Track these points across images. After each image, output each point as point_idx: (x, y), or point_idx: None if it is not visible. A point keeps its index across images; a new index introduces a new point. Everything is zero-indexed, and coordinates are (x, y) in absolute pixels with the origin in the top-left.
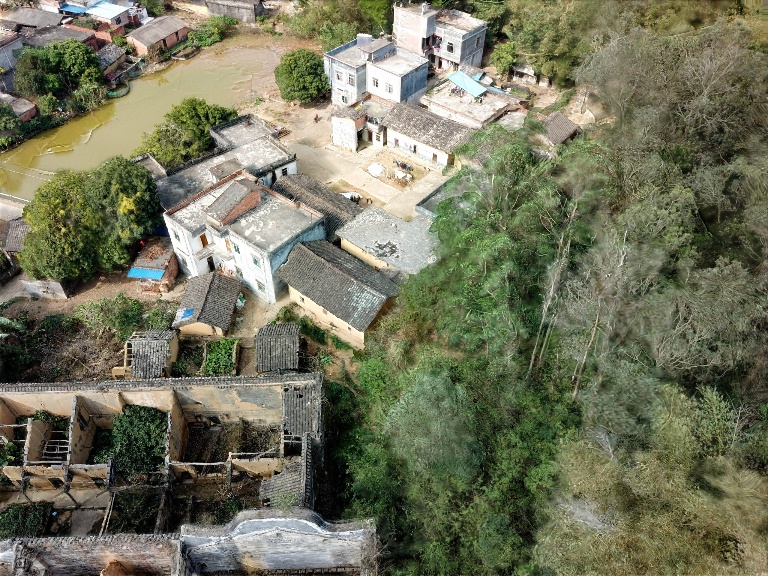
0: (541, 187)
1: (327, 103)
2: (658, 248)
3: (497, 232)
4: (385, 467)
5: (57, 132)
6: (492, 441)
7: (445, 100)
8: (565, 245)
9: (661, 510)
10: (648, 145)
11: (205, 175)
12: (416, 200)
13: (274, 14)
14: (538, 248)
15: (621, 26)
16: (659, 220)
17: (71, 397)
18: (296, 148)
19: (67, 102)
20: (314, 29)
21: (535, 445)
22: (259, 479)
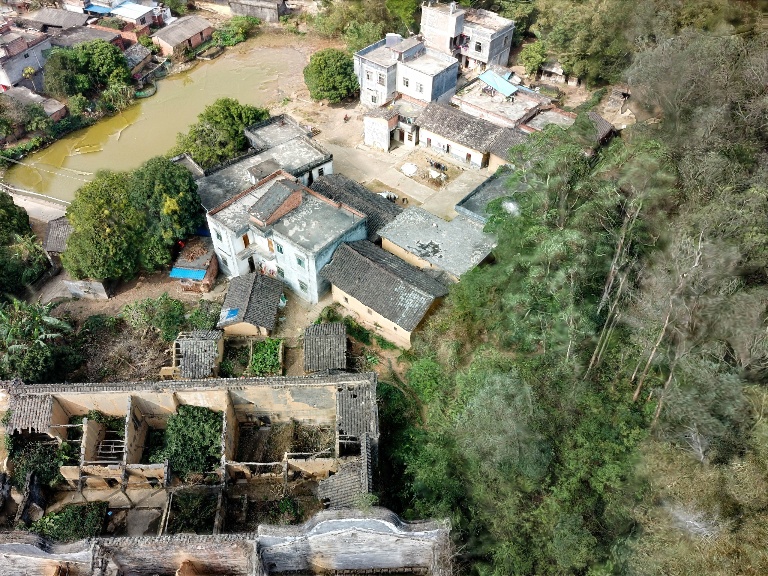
0: (600, 187)
1: (355, 103)
2: (729, 248)
3: (562, 232)
4: (446, 467)
5: (87, 132)
6: (555, 441)
7: (476, 100)
8: (626, 245)
9: (763, 511)
10: (713, 145)
11: (243, 175)
12: (452, 200)
13: (297, 14)
14: (597, 248)
15: (657, 25)
16: (732, 220)
17: (125, 397)
18: (327, 148)
19: (96, 102)
20: (338, 29)
21: (598, 445)
22: (312, 479)
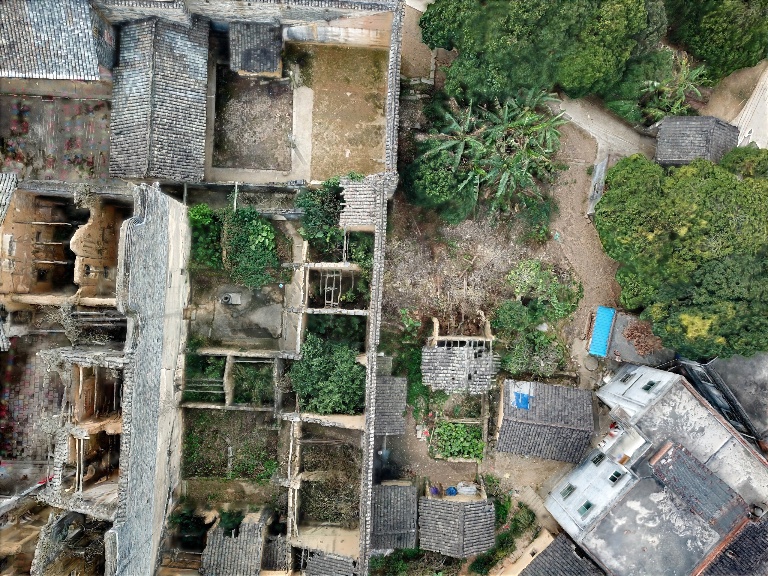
0: None
1: None
2: None
3: None
4: None
5: None
6: None
7: None
8: None
9: None
10: None
11: None
12: None
13: None
14: None
15: None
16: None
17: None
18: None
19: None
20: None
21: None
22: None
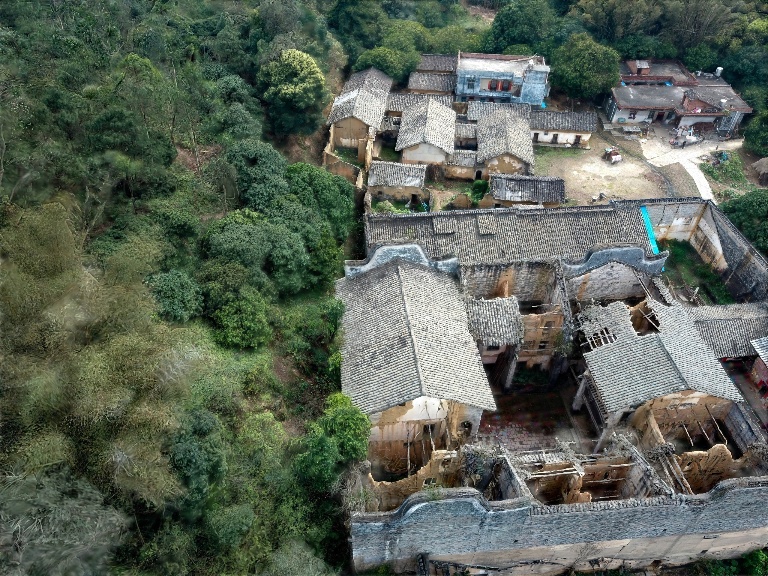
0: None
1: None
2: None
3: None
4: None
5: None
6: None
7: None
8: None
9: (116, 383)
10: None
11: None
12: None
13: None
14: None
15: None
16: None
17: None
18: None
19: None
20: None
21: None
22: None
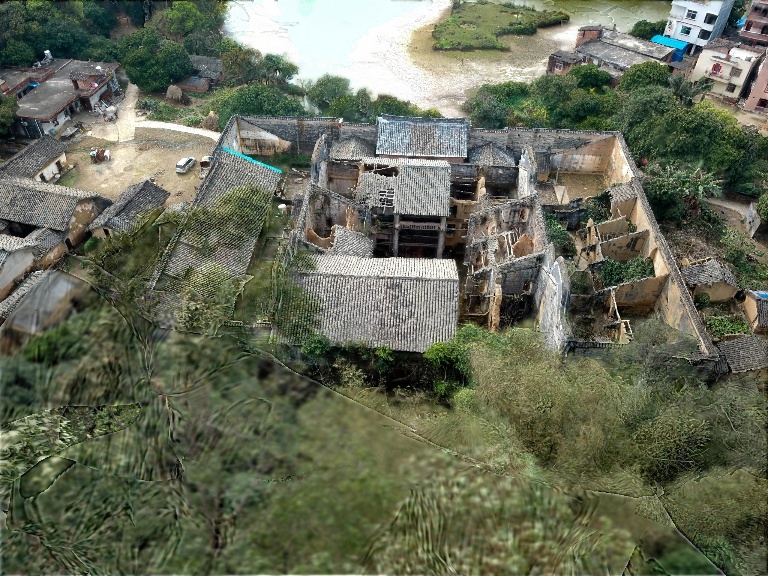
0: None
1: None
2: None
3: None
4: None
5: None
6: None
7: None
8: None
9: None
10: None
11: None
12: None
13: None
14: None
15: None
16: None
17: None
18: None
19: None
20: None
21: None
22: None
